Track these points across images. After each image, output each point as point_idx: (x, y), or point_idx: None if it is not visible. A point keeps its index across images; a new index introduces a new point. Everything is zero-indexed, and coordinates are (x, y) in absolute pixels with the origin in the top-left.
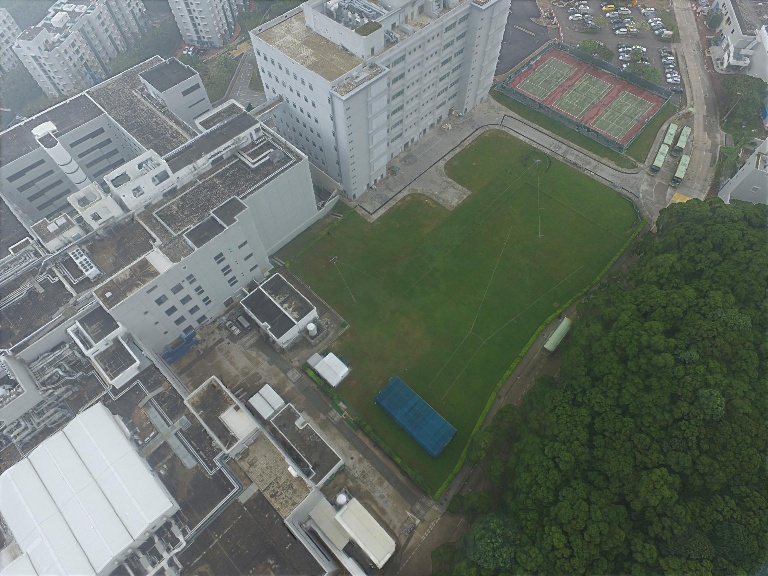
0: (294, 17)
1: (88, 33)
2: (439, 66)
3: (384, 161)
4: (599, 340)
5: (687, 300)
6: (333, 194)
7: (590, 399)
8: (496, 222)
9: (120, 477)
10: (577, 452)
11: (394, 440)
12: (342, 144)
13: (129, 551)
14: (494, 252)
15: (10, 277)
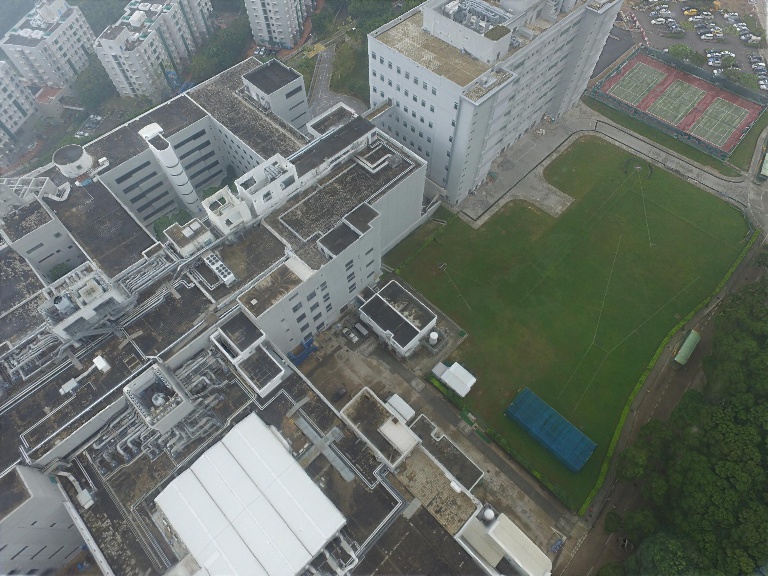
0: (408, 20)
1: (163, 32)
2: (547, 71)
3: (488, 167)
4: (757, 356)
5: None
6: (434, 199)
7: (756, 417)
8: (604, 230)
9: (289, 490)
10: (753, 472)
11: (529, 453)
12: (459, 150)
13: (307, 567)
14: (606, 261)
15: (148, 282)
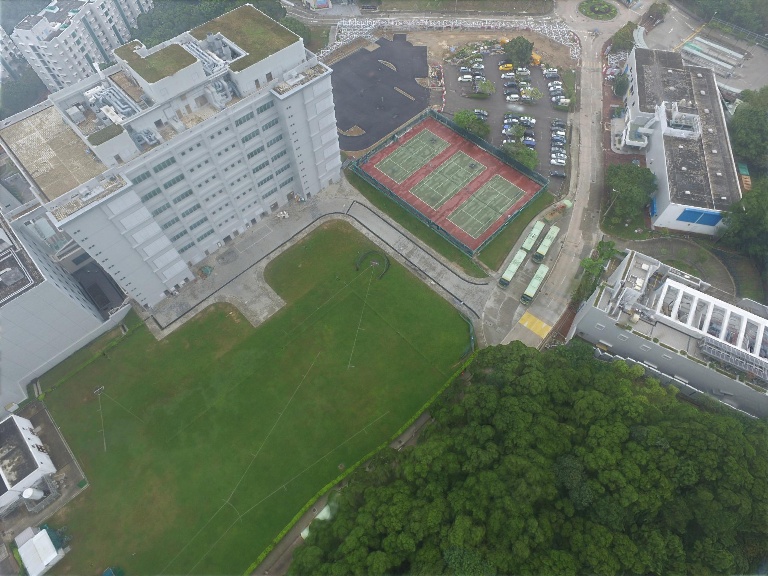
0: None
1: None
2: (245, 158)
3: (182, 266)
4: (308, 575)
5: (428, 525)
6: (125, 301)
7: None
8: (303, 346)
9: None
10: None
11: None
12: None
13: None
14: (288, 388)
15: None
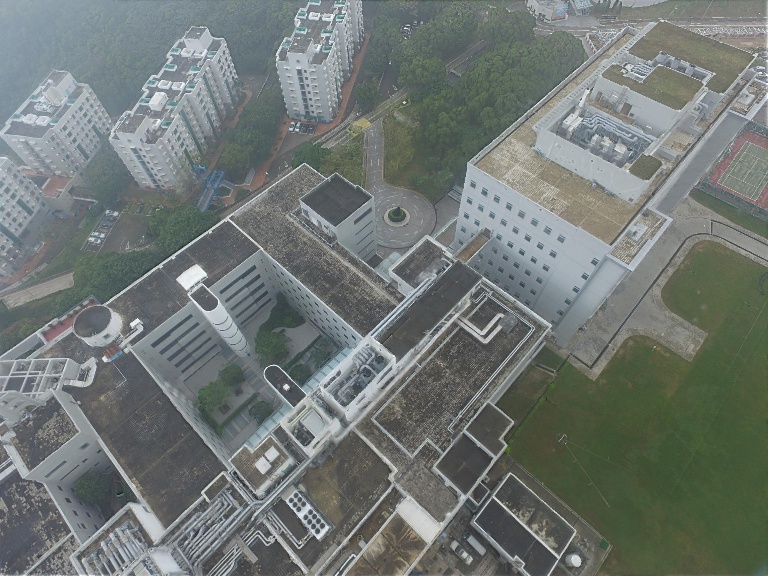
0: (512, 136)
1: (187, 114)
2: None
3: None
4: None
5: None
6: None
7: None
8: (754, 379)
9: None
10: None
11: None
12: (586, 302)
13: None
14: (766, 426)
15: (214, 544)
